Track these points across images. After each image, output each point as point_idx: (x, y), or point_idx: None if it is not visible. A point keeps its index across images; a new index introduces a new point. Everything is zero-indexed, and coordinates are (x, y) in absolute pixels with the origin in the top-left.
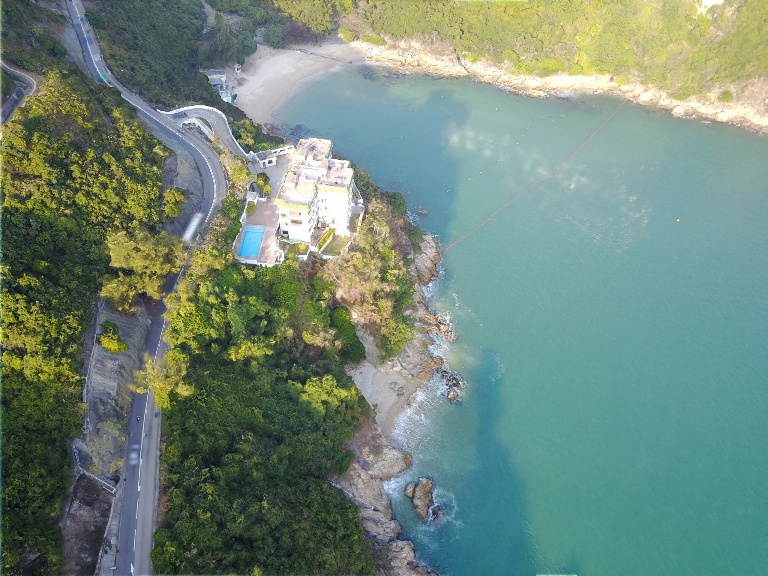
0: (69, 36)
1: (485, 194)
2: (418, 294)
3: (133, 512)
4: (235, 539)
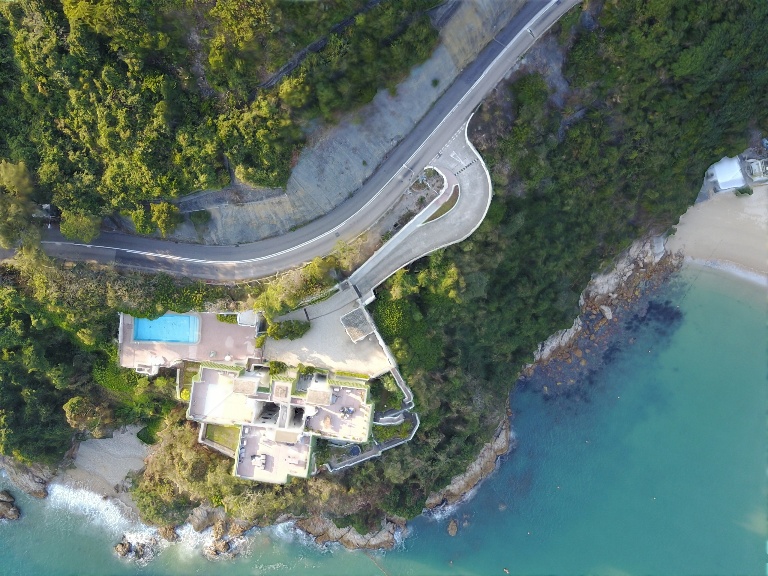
0: None
1: None
2: None
3: None
4: None
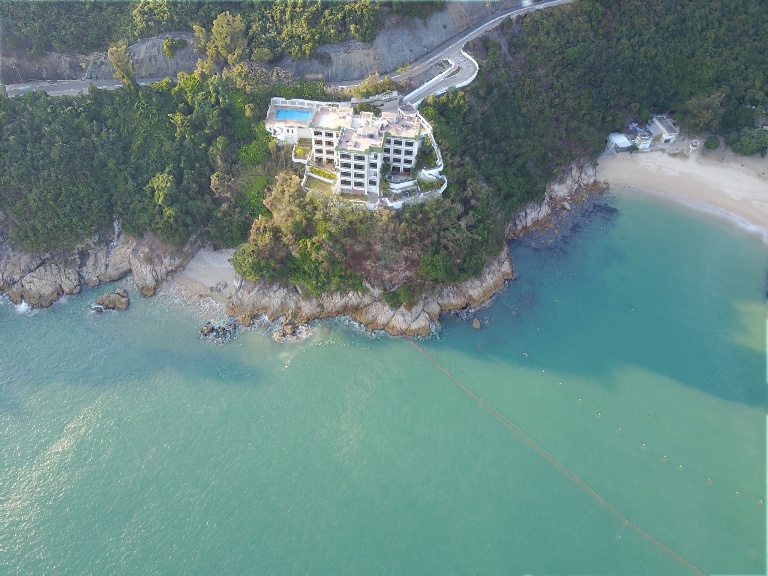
0: None
1: (531, 400)
2: (332, 305)
3: None
4: (44, 135)
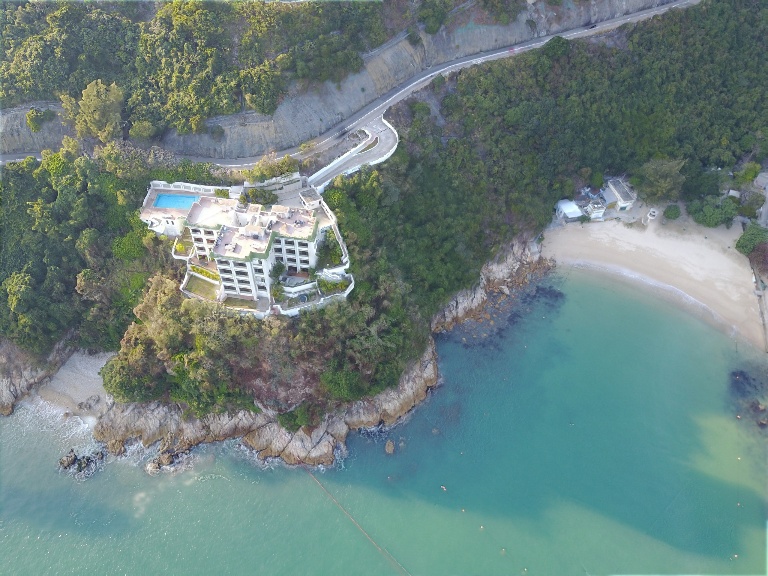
0: (488, 31)
1: (446, 550)
2: (219, 427)
3: None
4: None
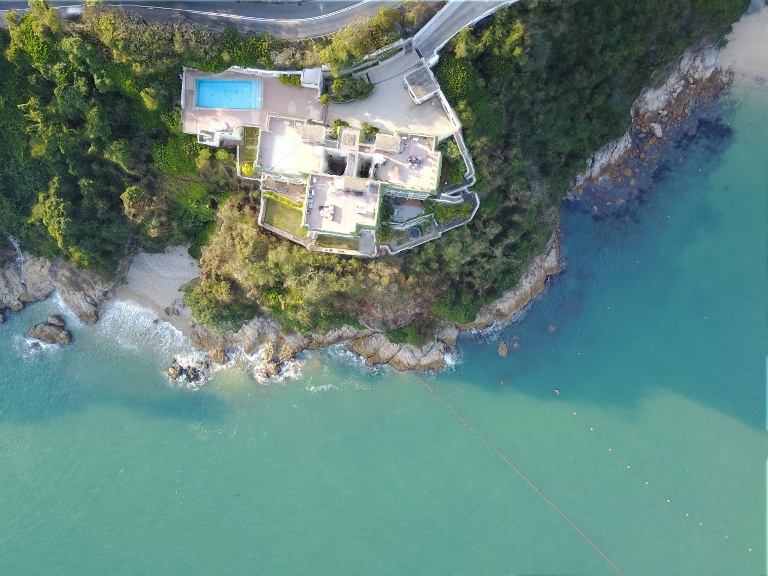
0: None
1: (555, 450)
2: (322, 337)
3: None
4: None
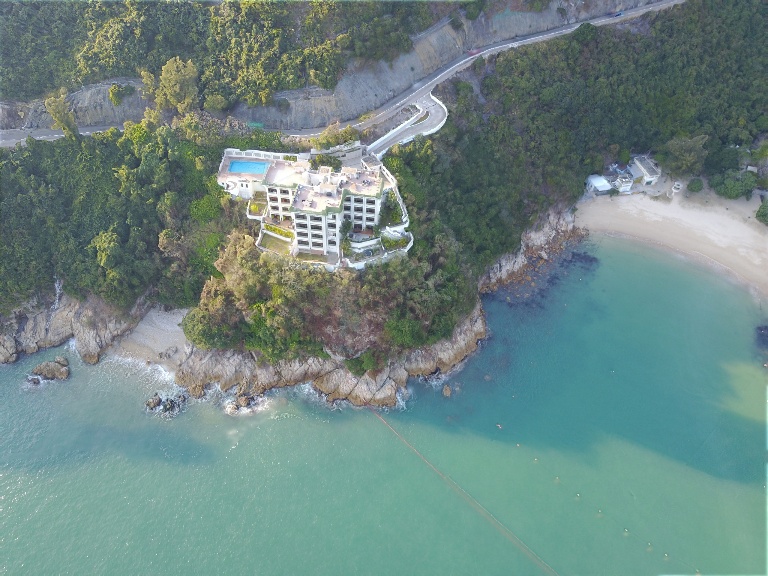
0: (523, 18)
1: (505, 479)
2: (290, 373)
3: (7, 139)
4: None
